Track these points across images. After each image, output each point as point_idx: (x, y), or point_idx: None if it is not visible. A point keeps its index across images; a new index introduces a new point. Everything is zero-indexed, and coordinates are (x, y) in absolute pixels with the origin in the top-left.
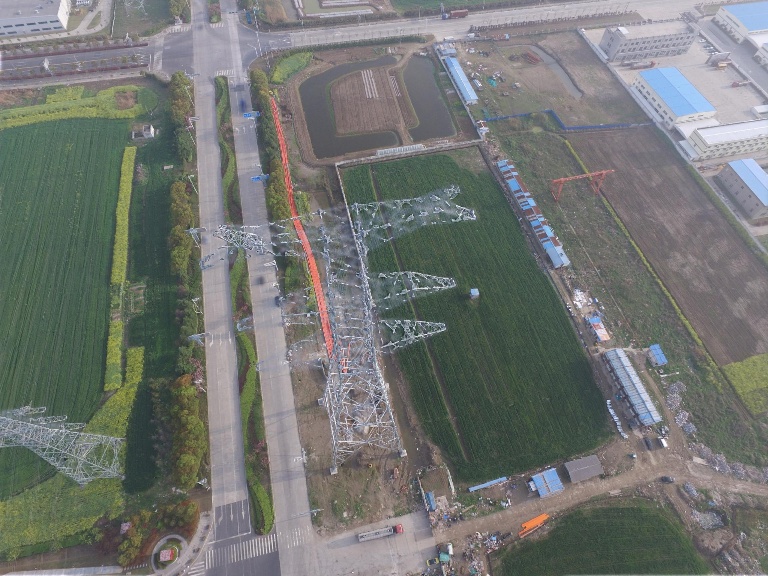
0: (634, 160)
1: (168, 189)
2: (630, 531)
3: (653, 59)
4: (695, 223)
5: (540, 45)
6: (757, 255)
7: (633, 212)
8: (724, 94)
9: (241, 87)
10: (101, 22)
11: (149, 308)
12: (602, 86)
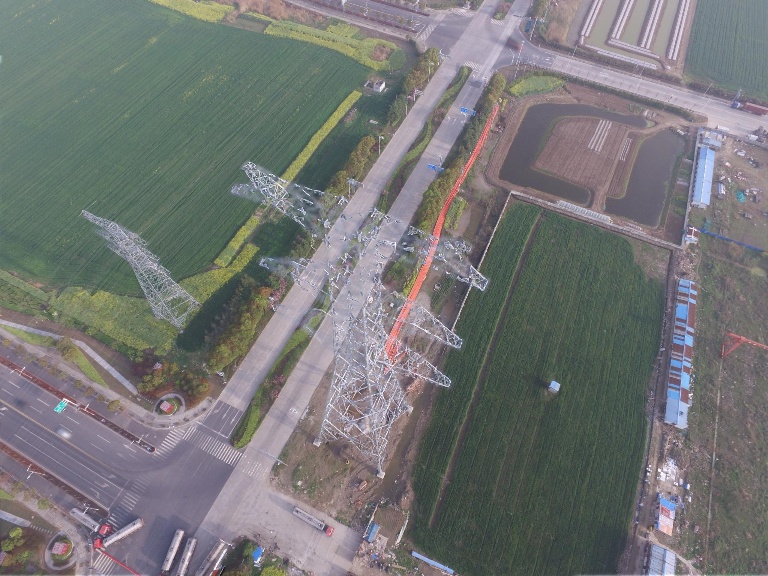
0: None
1: None
2: None
3: None
4: None
5: None
6: None
7: None
8: None
9: (478, 84)
10: None
11: (283, 222)
12: None
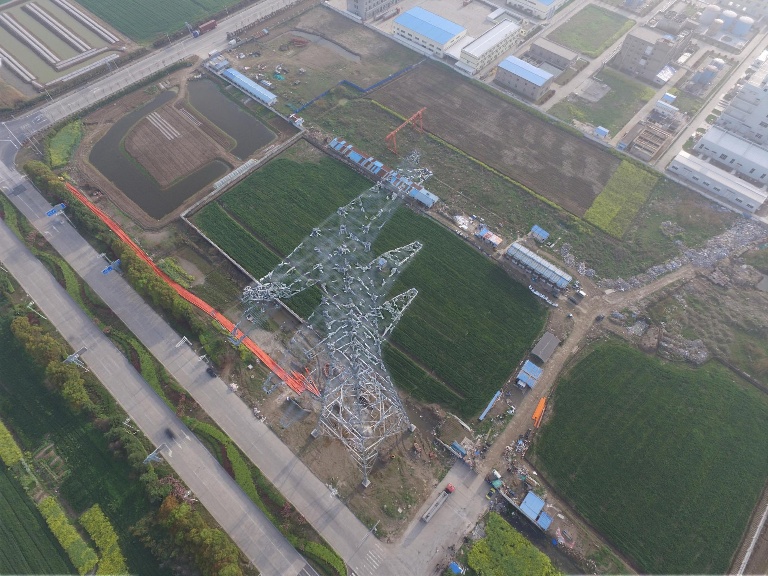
0: (432, 93)
1: (7, 333)
2: (601, 370)
3: (395, 6)
4: (503, 122)
5: (299, 28)
6: (555, 125)
7: (457, 134)
8: (462, 14)
9: (20, 188)
10: None
11: (74, 463)
12: (371, 43)
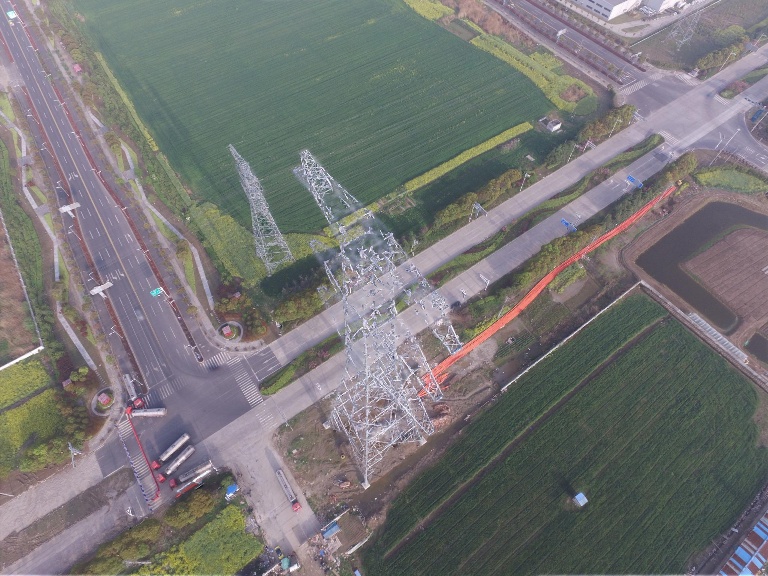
0: None
1: None
2: None
3: None
4: None
5: None
6: None
7: None
8: None
9: (664, 157)
10: (637, 32)
11: (398, 219)
12: None
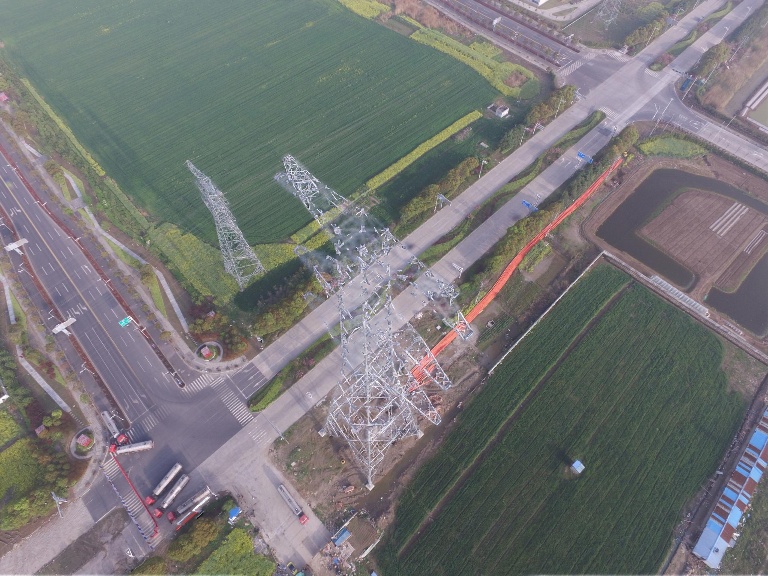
0: None
1: None
2: None
3: None
4: None
5: None
6: None
7: None
8: None
9: (608, 132)
10: (567, 15)
11: (364, 218)
12: None
